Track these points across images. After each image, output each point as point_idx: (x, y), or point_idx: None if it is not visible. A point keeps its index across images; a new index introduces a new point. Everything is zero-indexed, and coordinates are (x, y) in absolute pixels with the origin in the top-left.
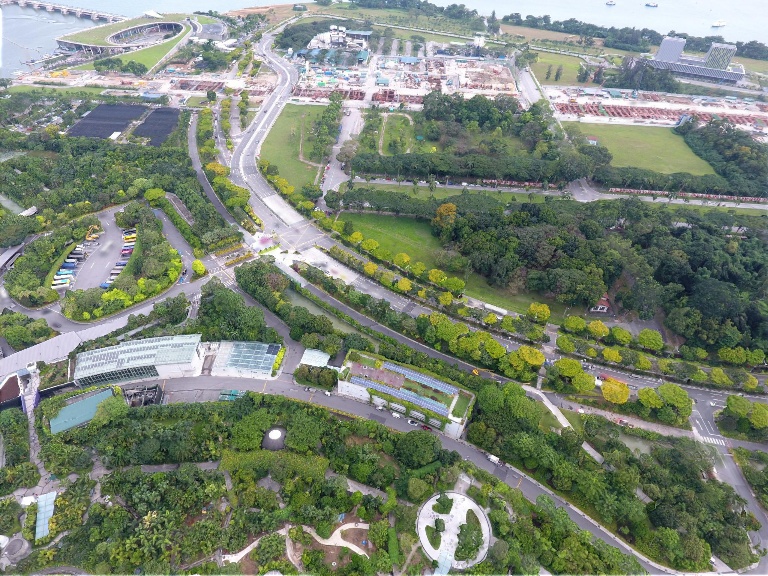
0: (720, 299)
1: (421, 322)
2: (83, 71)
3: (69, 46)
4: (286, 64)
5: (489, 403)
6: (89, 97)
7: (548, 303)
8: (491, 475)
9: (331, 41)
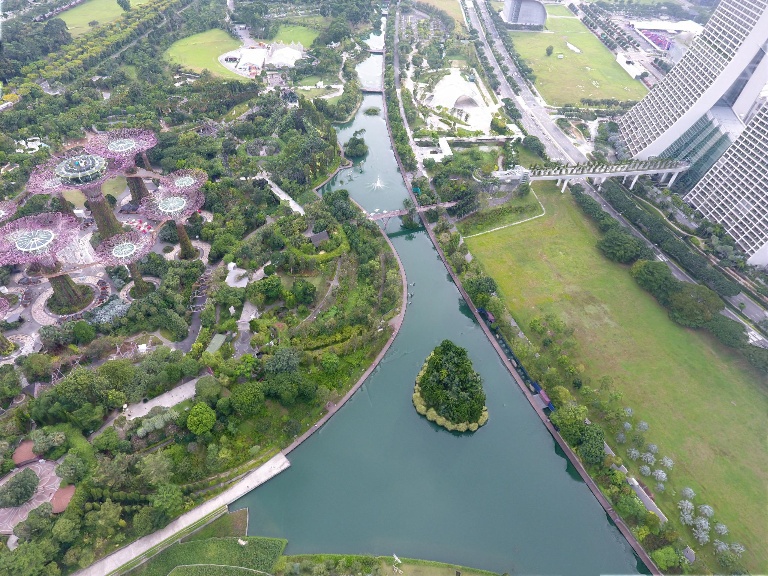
0: None
1: None
2: None
3: None
4: None
5: None
6: None
7: None
8: None
9: None
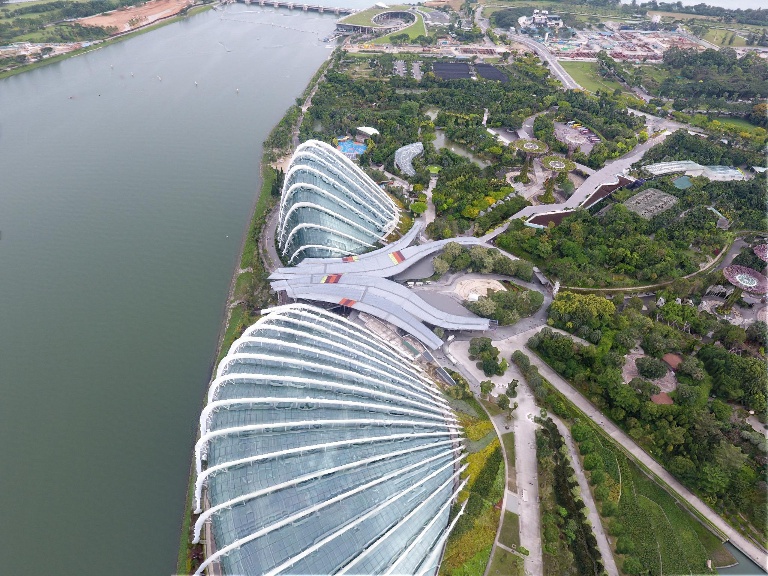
0: None
1: None
2: (381, 44)
3: (348, 28)
4: (520, 37)
5: None
6: (416, 59)
7: None
8: None
9: (534, 22)
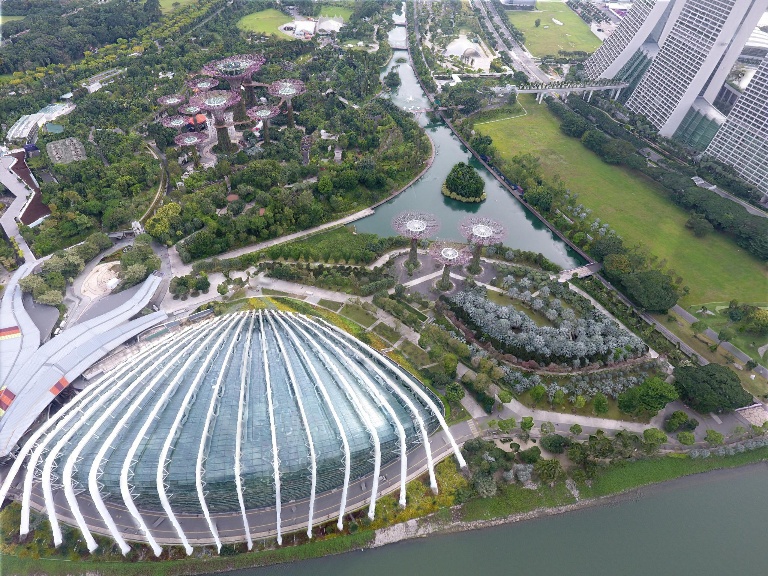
0: (118, 18)
1: (71, 71)
2: None
3: None
4: None
5: (126, 59)
6: None
7: (83, 59)
8: None
9: None
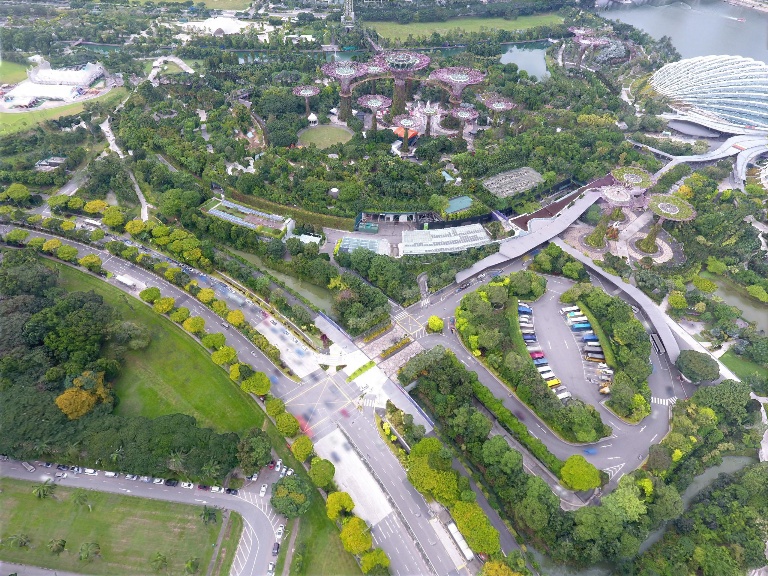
0: None
1: (210, 251)
2: None
3: None
4: None
5: None
6: None
7: None
8: (215, 177)
9: None
